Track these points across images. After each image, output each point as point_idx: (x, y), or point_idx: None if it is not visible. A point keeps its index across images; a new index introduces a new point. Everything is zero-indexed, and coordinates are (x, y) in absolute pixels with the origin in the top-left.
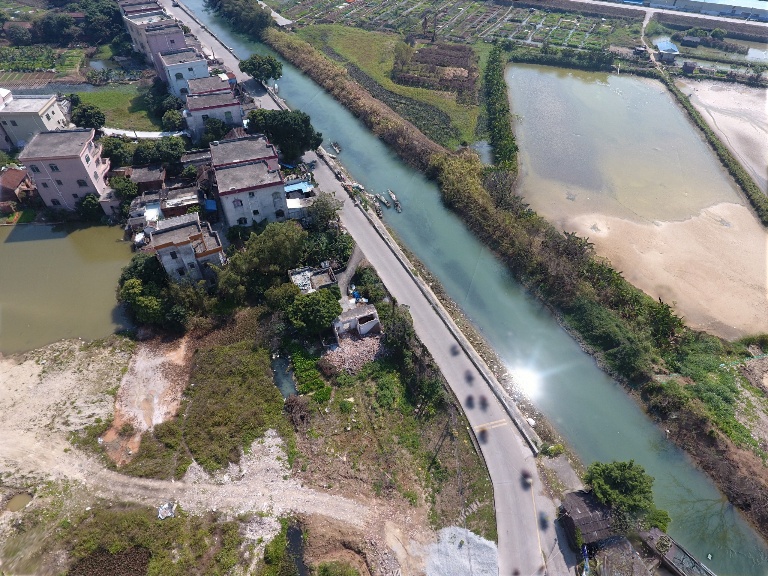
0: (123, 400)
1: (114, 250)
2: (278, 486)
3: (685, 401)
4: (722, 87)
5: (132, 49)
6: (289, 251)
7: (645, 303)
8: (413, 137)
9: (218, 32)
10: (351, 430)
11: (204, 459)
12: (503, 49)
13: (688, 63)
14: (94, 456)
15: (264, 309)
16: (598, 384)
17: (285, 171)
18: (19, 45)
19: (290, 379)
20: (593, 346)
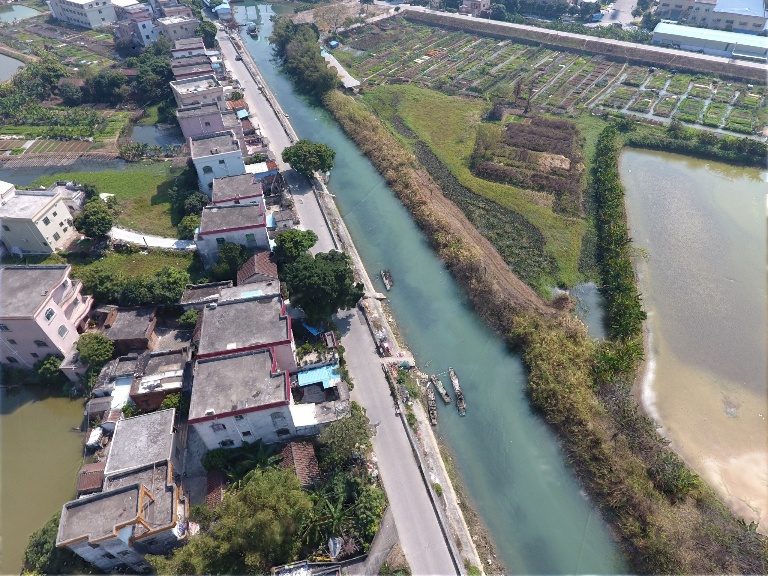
0: None
1: (61, 449)
2: None
3: None
4: None
5: None
6: (277, 536)
7: None
8: (492, 281)
9: (278, 92)
10: None
11: None
12: (617, 129)
13: None
14: None
15: None
16: None
17: (304, 348)
18: (67, 105)
19: None
20: None
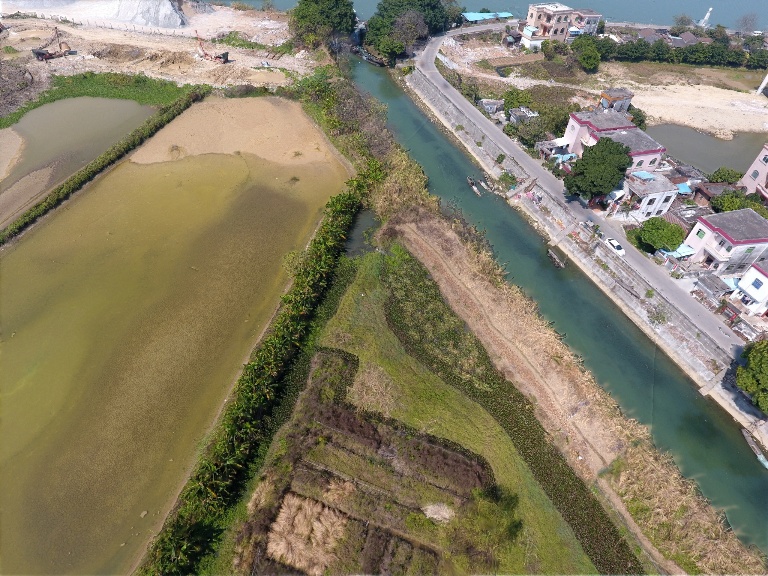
0: None
1: None
2: (513, 81)
3: None
4: None
5: None
6: None
7: None
8: None
9: None
10: None
11: None
12: None
13: None
14: None
15: None
16: None
17: None
18: None
19: None
20: None
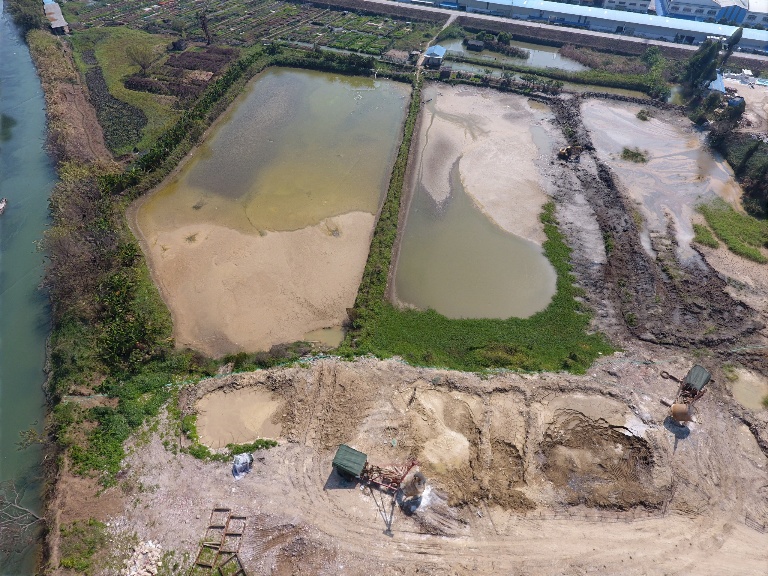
0: None
1: None
2: None
3: (64, 425)
4: (471, 92)
5: None
6: None
7: (149, 318)
8: (61, 143)
9: None
10: None
11: None
12: (267, 52)
13: (443, 67)
14: None
15: None
16: (29, 405)
17: None
18: None
19: None
20: (52, 365)
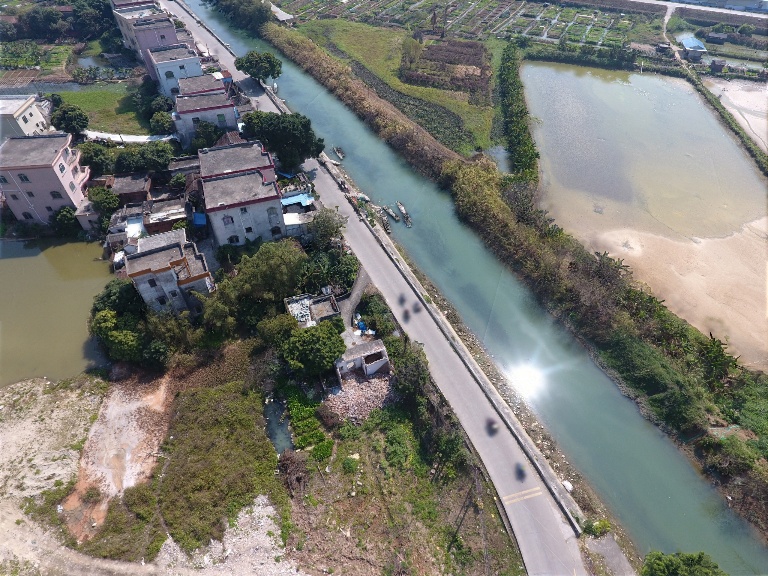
0: (90, 456)
1: (90, 271)
2: (269, 570)
3: (750, 463)
4: (754, 87)
5: (122, 45)
6: (285, 276)
7: (691, 337)
8: (424, 142)
9: (215, 27)
10: (356, 496)
11: (181, 535)
12: (518, 46)
13: (717, 61)
14: (51, 529)
15: (257, 342)
16: (642, 436)
17: (282, 182)
18: (3, 41)
19: (285, 429)
20: (635, 389)
